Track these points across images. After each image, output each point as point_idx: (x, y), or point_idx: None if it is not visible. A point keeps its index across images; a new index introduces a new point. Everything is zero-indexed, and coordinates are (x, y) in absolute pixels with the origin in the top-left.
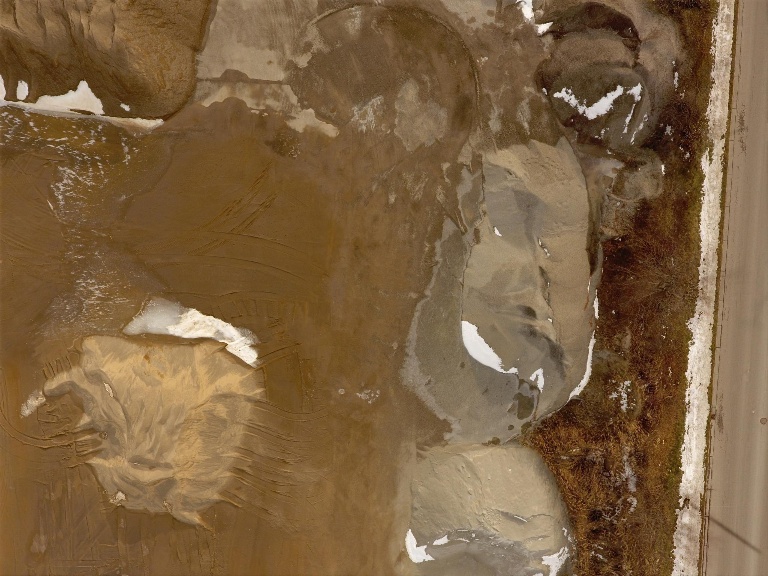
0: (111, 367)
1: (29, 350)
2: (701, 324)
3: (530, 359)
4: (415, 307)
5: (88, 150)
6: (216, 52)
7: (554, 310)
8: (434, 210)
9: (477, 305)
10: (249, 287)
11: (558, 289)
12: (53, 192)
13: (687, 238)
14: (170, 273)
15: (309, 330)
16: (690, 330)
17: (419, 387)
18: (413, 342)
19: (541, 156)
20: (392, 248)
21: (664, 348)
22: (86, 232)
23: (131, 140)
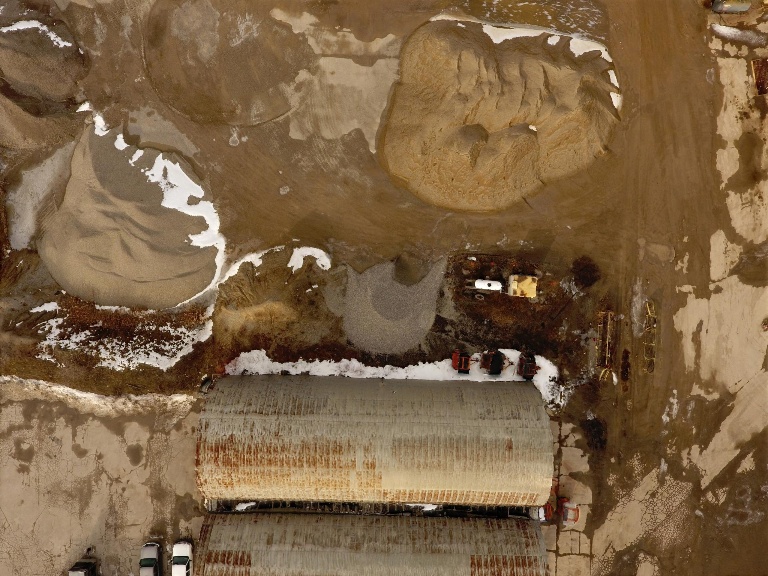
0: None
1: None
2: None
3: None
4: None
5: None
6: (381, 82)
7: None
8: None
9: None
10: None
11: None
12: None
13: None
14: None
15: None
16: None
17: None
18: None
19: None
20: None
21: None
22: None
23: (460, 4)
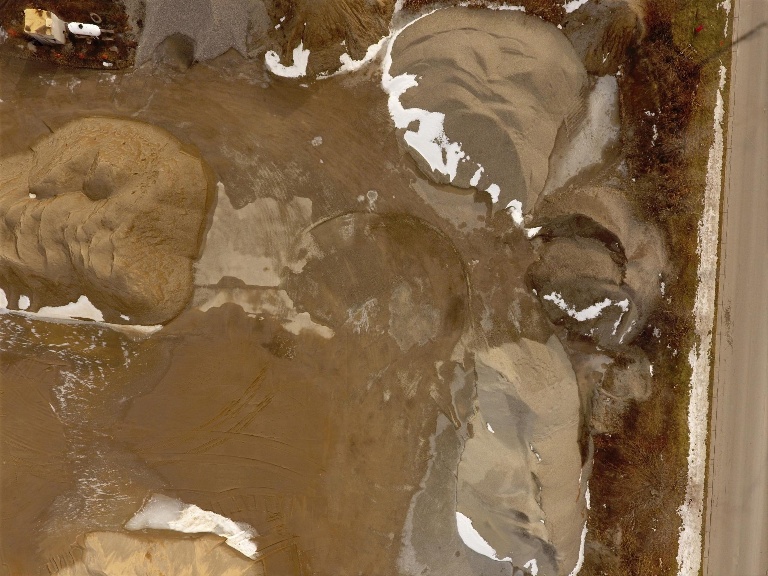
0: (113, 569)
1: (33, 546)
2: (691, 511)
3: (524, 553)
4: (411, 499)
5: (89, 355)
6: (213, 260)
7: (546, 512)
8: (428, 406)
9: (471, 500)
10: (248, 483)
11: (550, 491)
12: (55, 395)
13: (676, 432)
14: (170, 471)
15: (307, 523)
16: (680, 517)
17: (415, 575)
18: (409, 532)
19: (532, 357)
20: (387, 444)
21: (654, 541)
22: (88, 433)
23: (131, 344)
